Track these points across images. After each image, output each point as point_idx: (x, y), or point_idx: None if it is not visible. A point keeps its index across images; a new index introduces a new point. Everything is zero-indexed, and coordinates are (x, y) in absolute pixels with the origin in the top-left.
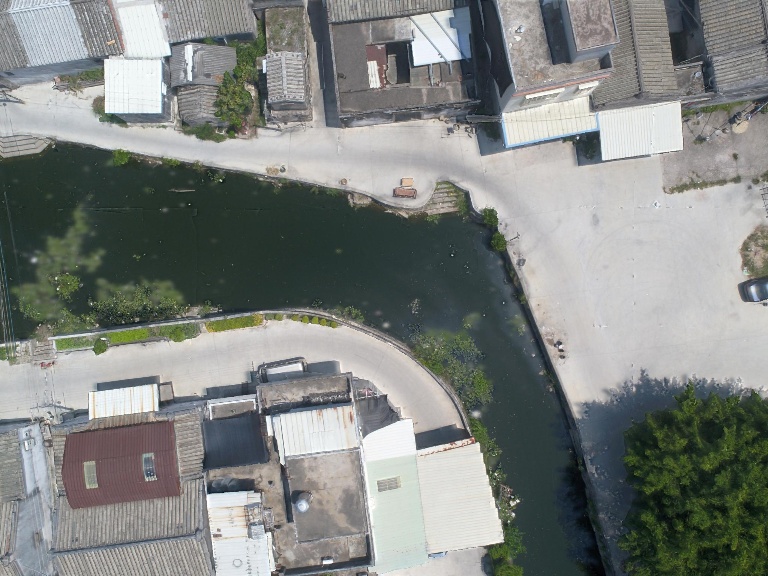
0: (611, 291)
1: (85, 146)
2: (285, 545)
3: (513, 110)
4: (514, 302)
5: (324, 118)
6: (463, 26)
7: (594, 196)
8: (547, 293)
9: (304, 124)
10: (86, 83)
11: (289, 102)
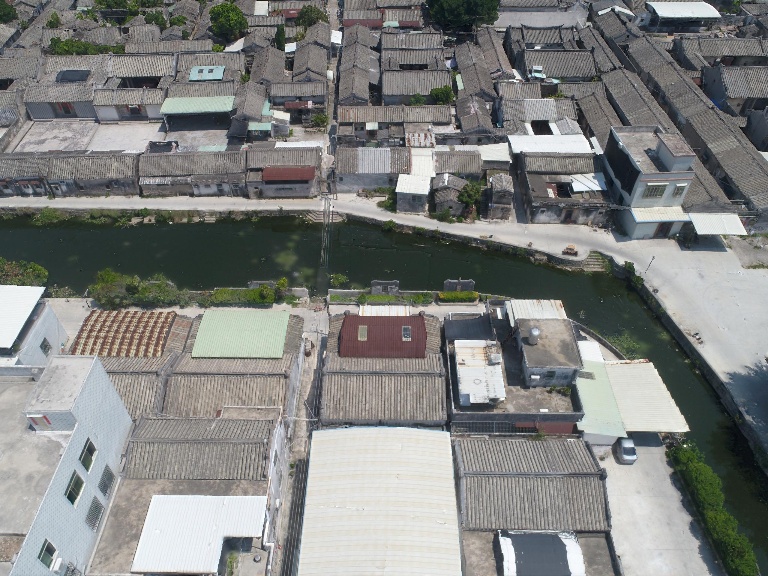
0: (725, 311)
1: (367, 220)
2: (506, 400)
3: (637, 207)
4: (654, 320)
5: (516, 219)
6: (600, 179)
7: (696, 265)
8: (678, 308)
9: (504, 221)
10: (376, 194)
11: (505, 193)
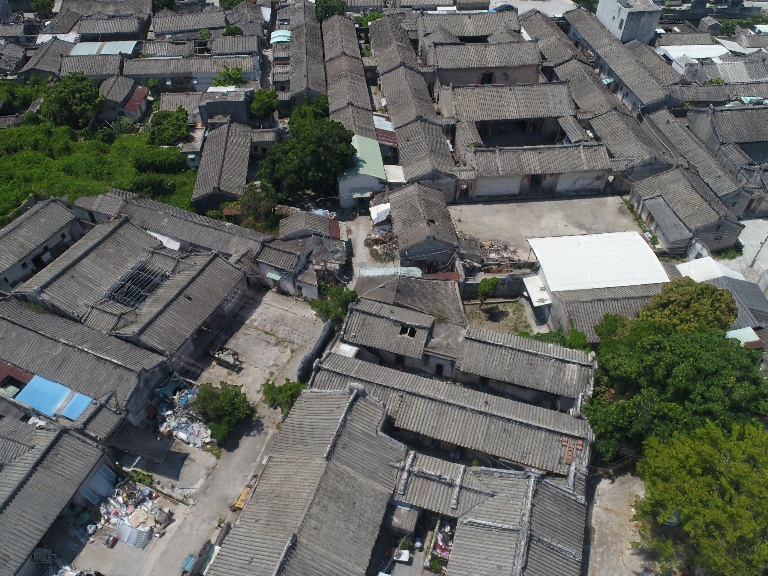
0: None
1: None
2: None
3: None
4: None
5: None
6: None
7: None
8: None
9: None
10: None
11: None
